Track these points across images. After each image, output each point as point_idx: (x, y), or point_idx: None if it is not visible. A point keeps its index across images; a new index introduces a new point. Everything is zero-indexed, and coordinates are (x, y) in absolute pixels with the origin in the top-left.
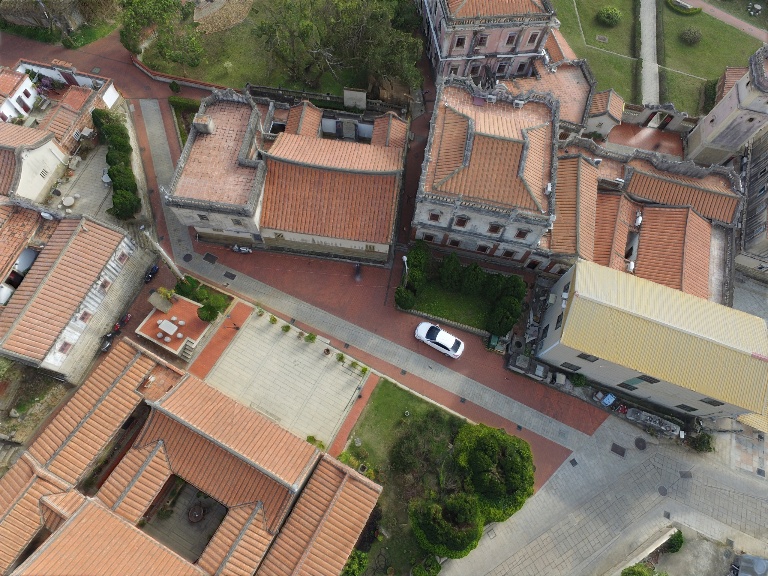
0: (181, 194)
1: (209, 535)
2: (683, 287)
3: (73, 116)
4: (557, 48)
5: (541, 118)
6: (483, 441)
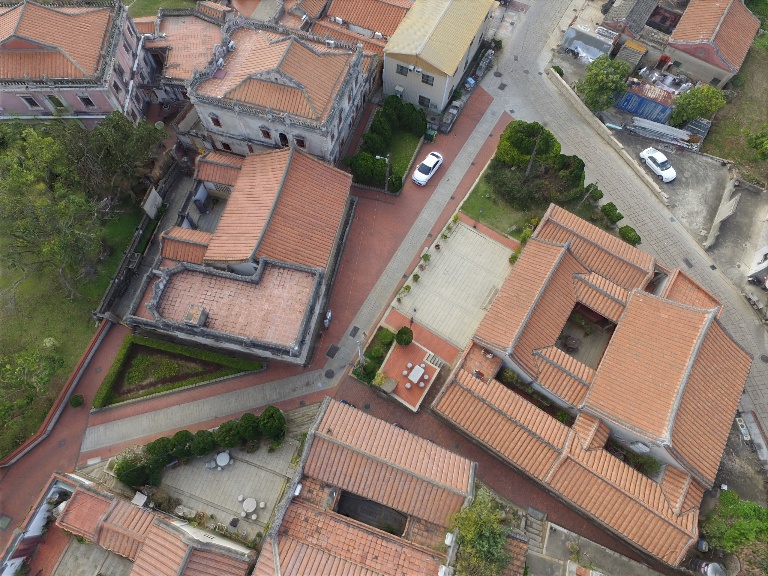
0: (288, 341)
1: (584, 337)
2: (404, 7)
3: (122, 506)
4: (137, 25)
5: (250, 35)
6: (515, 141)
